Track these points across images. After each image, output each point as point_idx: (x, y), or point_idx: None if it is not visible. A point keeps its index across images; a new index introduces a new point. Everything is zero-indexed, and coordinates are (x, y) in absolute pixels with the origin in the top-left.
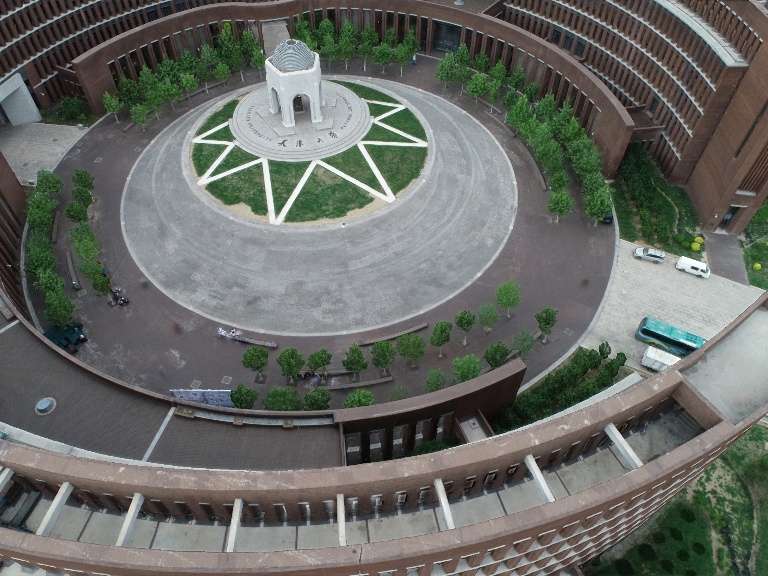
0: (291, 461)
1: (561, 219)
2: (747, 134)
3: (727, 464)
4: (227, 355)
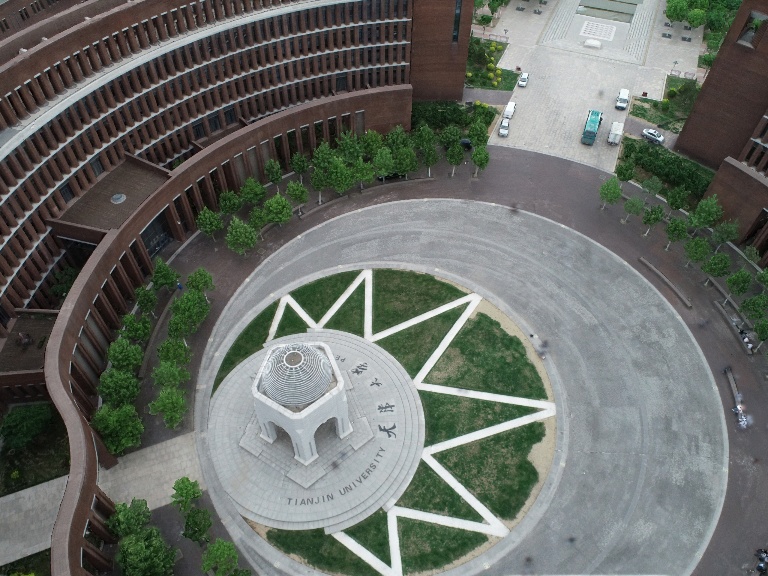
0: None
1: (472, 173)
2: (454, 21)
3: (671, 123)
4: (761, 413)
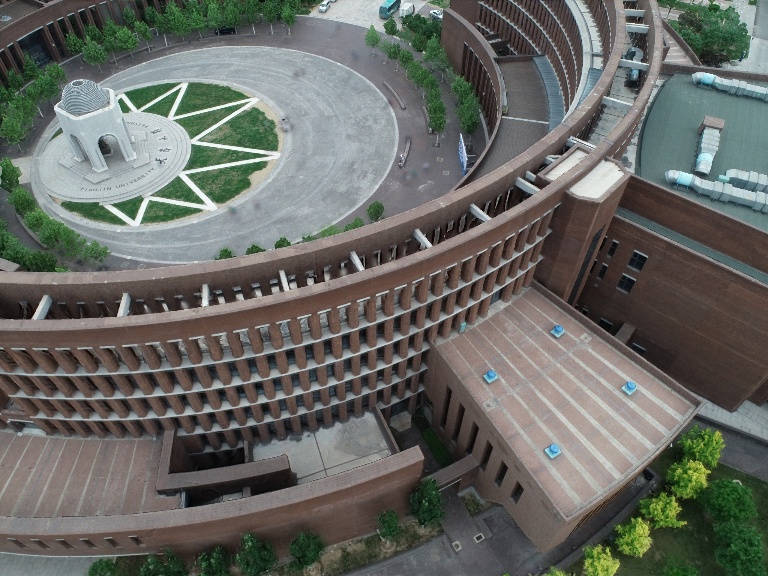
0: (521, 75)
1: None
2: None
3: None
4: (419, 162)
